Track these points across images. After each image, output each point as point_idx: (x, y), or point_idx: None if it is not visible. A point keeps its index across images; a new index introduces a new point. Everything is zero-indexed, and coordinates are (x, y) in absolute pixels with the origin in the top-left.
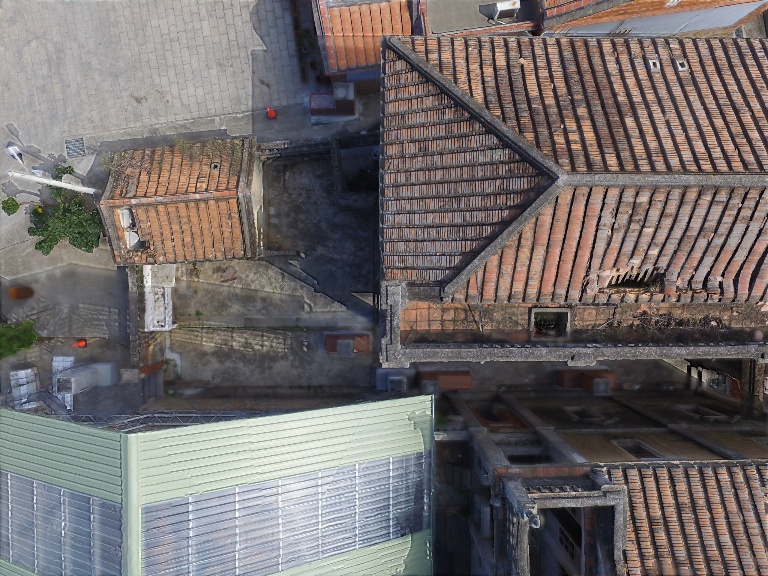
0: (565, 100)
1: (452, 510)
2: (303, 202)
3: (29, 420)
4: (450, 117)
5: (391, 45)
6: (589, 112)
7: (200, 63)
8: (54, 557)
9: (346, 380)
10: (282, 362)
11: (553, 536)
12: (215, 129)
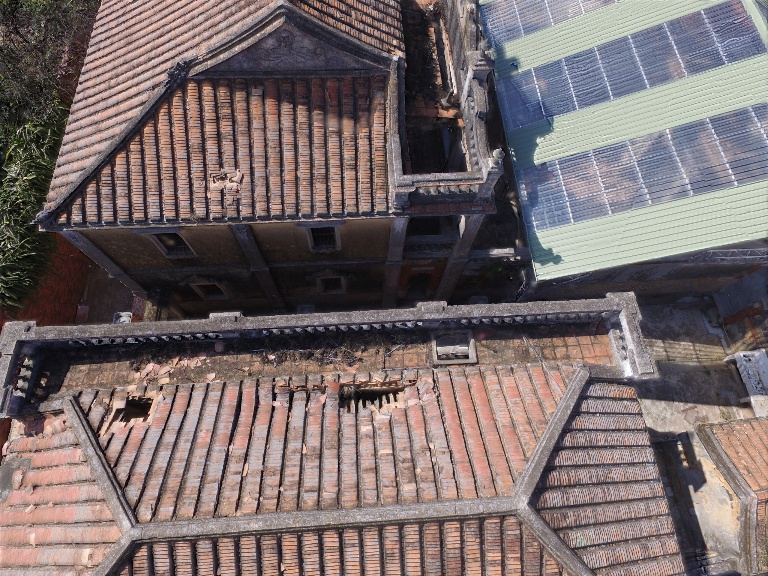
0: None
1: None
2: None
3: None
4: None
5: None
6: None
7: None
8: None
9: None
10: None
11: None
12: None
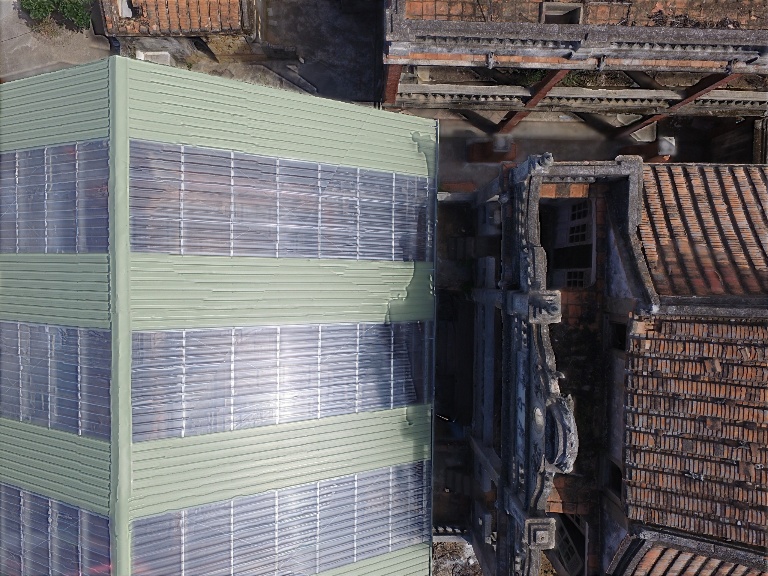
0: None
1: (455, 287)
2: (303, 4)
3: (11, 87)
4: None
5: None
6: None
7: None
8: (37, 227)
9: None
10: None
11: (560, 287)
12: None
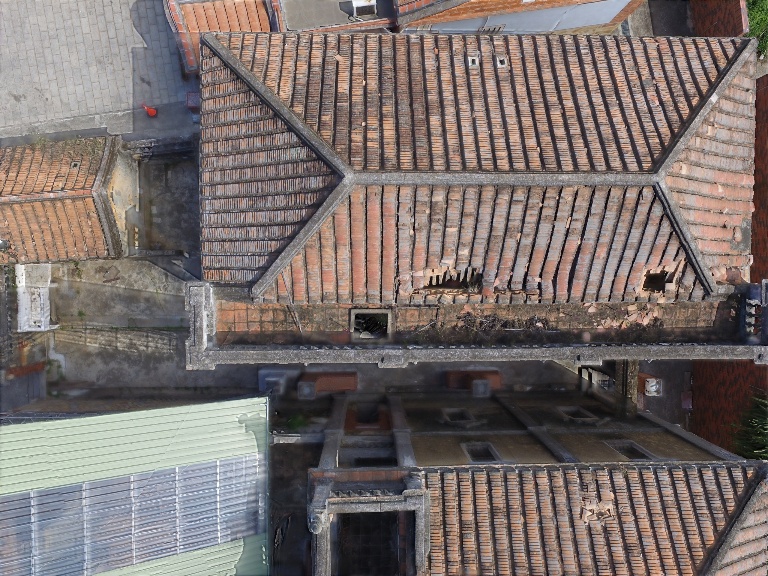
0: (373, 97)
1: None
2: (186, 201)
3: None
4: (257, 115)
5: (205, 41)
6: (396, 110)
7: (80, 61)
8: None
9: (233, 381)
10: (168, 363)
11: None
12: (95, 127)
